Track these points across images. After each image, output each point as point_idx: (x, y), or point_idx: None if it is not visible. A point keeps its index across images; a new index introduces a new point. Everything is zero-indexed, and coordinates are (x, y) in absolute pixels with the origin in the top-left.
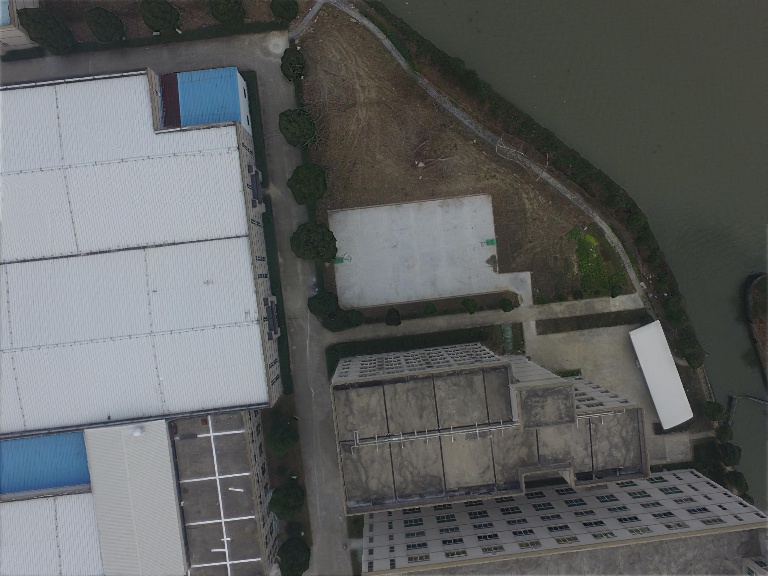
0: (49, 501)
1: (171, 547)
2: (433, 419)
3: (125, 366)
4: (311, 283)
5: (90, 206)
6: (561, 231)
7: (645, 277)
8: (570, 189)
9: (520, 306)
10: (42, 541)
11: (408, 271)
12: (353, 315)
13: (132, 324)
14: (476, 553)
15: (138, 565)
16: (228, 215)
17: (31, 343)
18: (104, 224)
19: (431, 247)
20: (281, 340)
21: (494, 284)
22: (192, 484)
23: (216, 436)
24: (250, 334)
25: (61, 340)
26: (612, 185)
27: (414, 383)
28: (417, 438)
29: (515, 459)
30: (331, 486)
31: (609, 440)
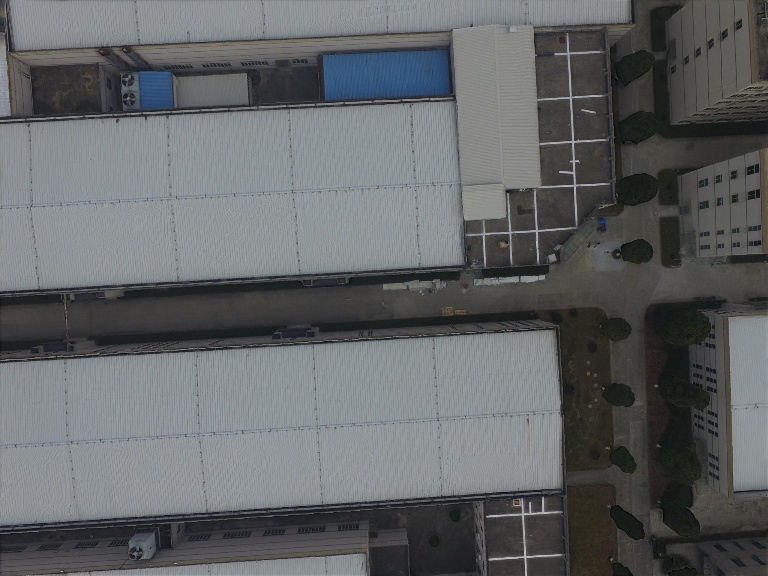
0: (405, 107)
1: (530, 155)
2: None
3: None
4: None
5: None
6: None
7: None
8: None
9: None
10: (397, 145)
11: None
12: None
13: None
14: None
15: (500, 167)
16: None
17: None
18: None
19: None
20: None
21: None
22: (545, 103)
23: (573, 55)
24: None
25: None
26: None
27: None
28: None
29: None
30: (646, 151)
31: None
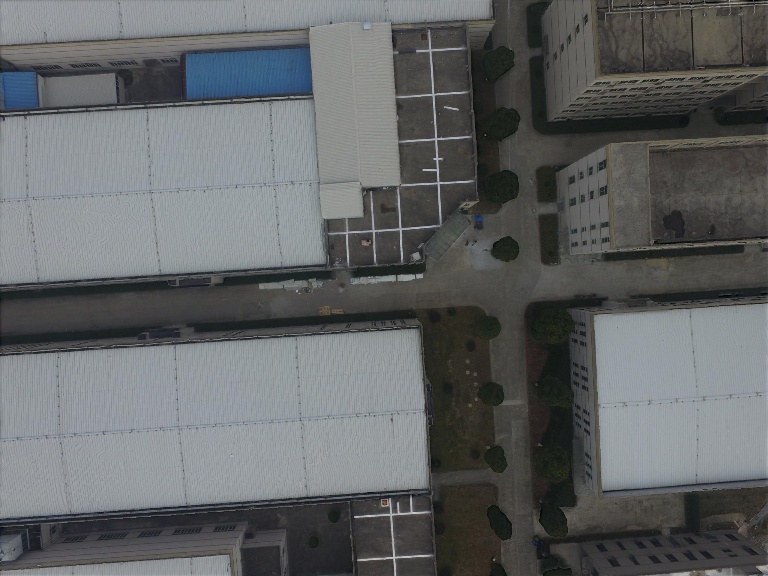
0: (265, 105)
1: (389, 153)
2: None
3: None
4: None
5: None
6: None
7: None
8: None
9: None
10: (256, 144)
11: None
12: None
13: None
14: None
15: (357, 165)
16: None
17: None
18: None
19: None
20: None
21: None
22: (408, 100)
23: (435, 52)
24: None
25: None
26: None
27: None
28: (670, 8)
29: (763, 40)
30: (524, 148)
31: None
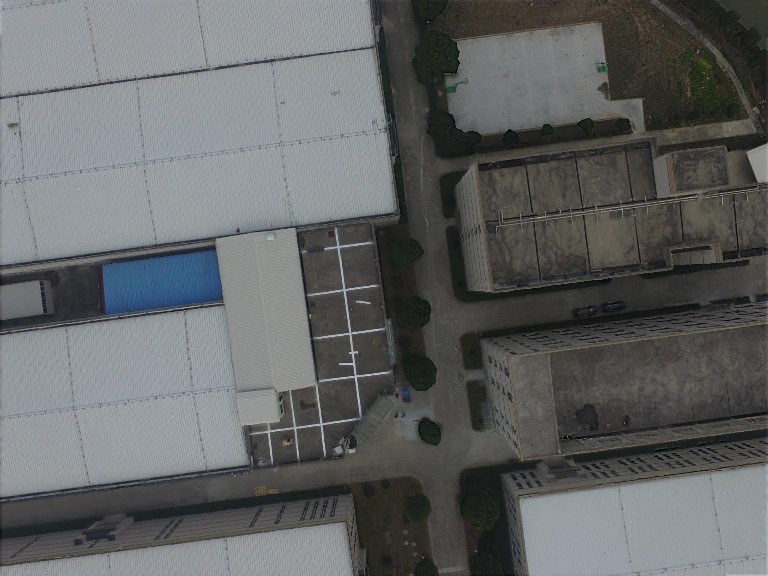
0: (179, 315)
1: (302, 355)
2: (576, 198)
3: (254, 177)
4: (424, 113)
5: (219, 20)
6: (674, 54)
7: (758, 102)
8: (680, 15)
9: (632, 133)
10: (173, 354)
11: (520, 100)
12: (472, 134)
13: (261, 135)
14: (620, 338)
15: (271, 372)
16: (354, 27)
17: (163, 155)
18: (233, 38)
19: (543, 75)
20: (396, 169)
21: (606, 111)
22: (319, 297)
23: (343, 248)
24: (377, 143)
25: (192, 152)
26: (722, 10)
27: (557, 163)
28: (562, 216)
29: (659, 238)
30: (446, 317)
31: (754, 218)
